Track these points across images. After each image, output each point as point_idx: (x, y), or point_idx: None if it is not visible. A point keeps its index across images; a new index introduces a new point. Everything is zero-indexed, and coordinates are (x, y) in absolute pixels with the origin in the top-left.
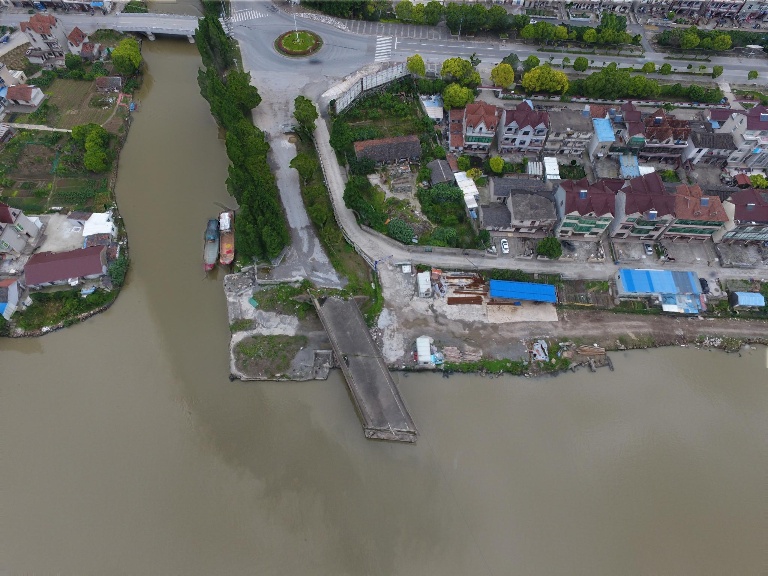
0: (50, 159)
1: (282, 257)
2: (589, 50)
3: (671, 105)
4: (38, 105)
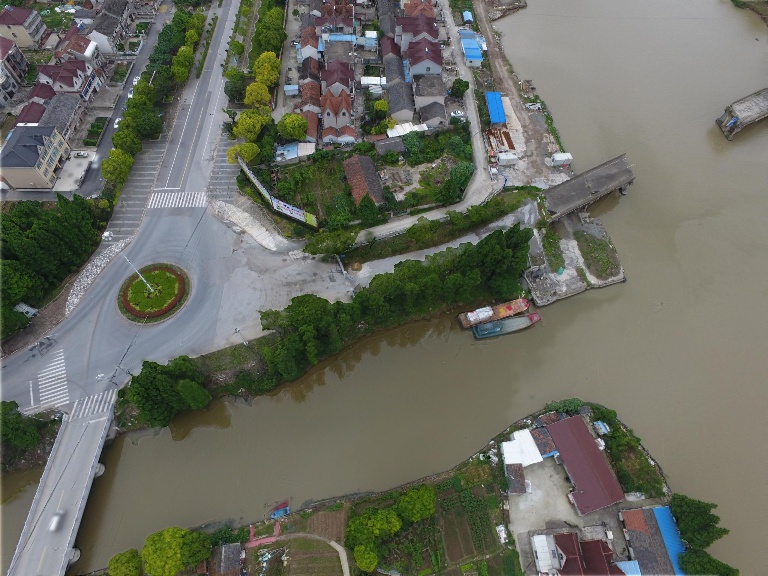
0: None
1: None
2: (201, 46)
3: (285, 14)
4: None
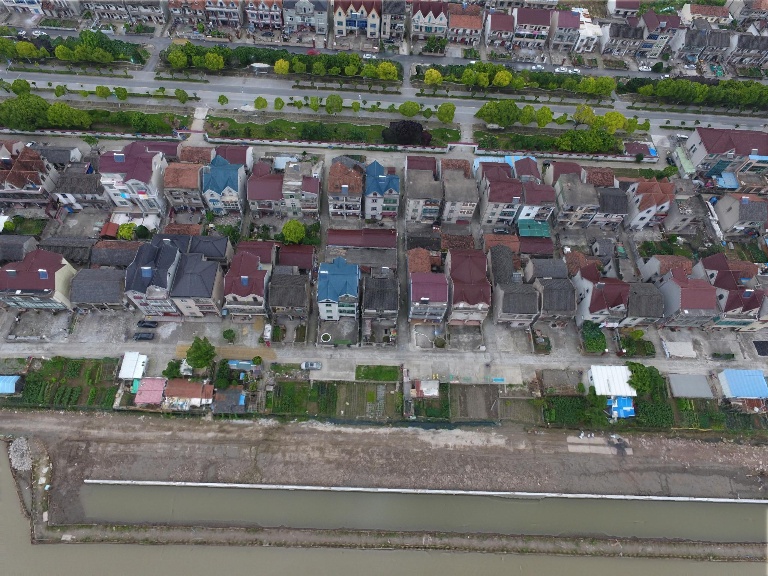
0: None
1: None
2: (73, 69)
3: (114, 136)
4: None
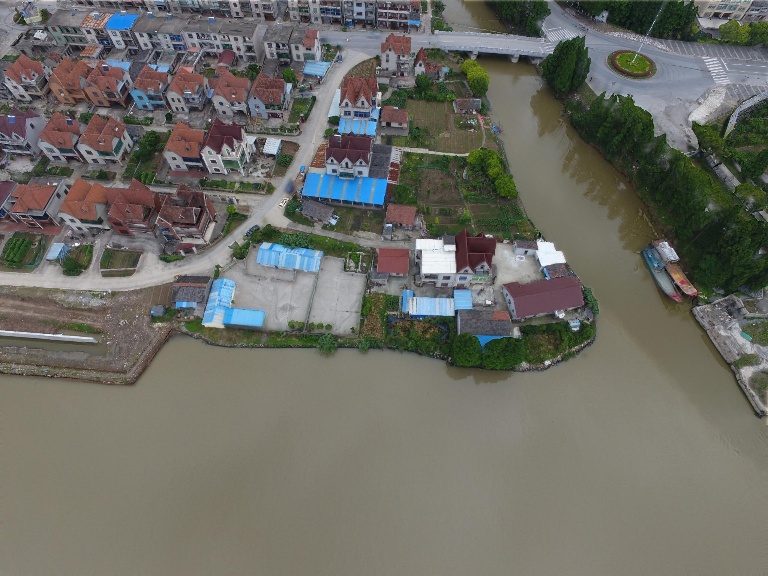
0: (458, 185)
1: (762, 290)
2: None
3: None
4: (407, 127)
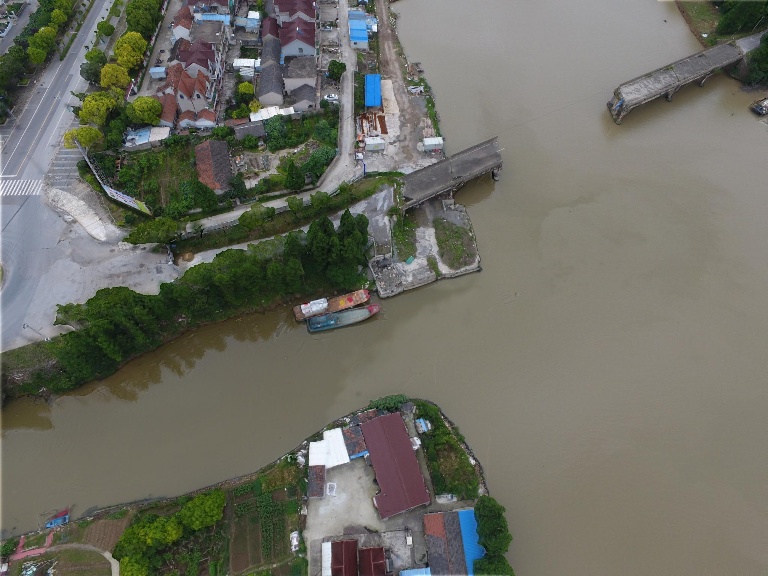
0: None
1: None
2: None
3: None
4: None
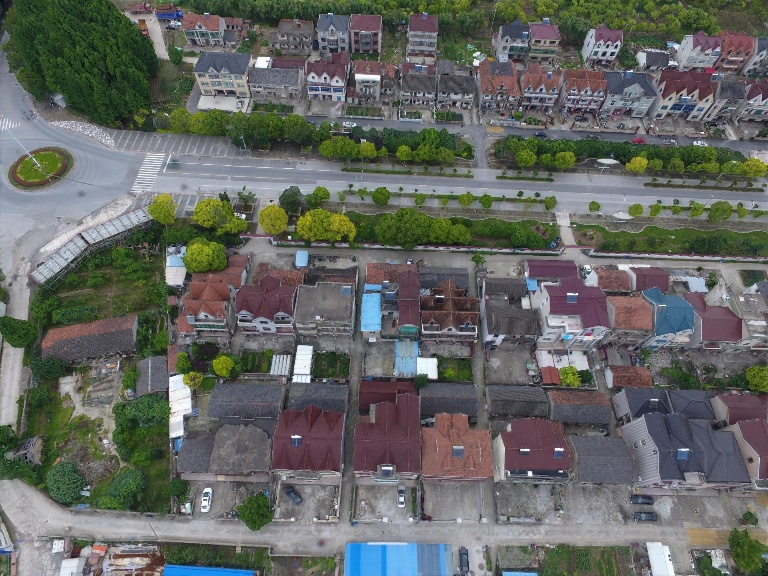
0: None
1: None
2: (407, 167)
3: (489, 250)
4: None
